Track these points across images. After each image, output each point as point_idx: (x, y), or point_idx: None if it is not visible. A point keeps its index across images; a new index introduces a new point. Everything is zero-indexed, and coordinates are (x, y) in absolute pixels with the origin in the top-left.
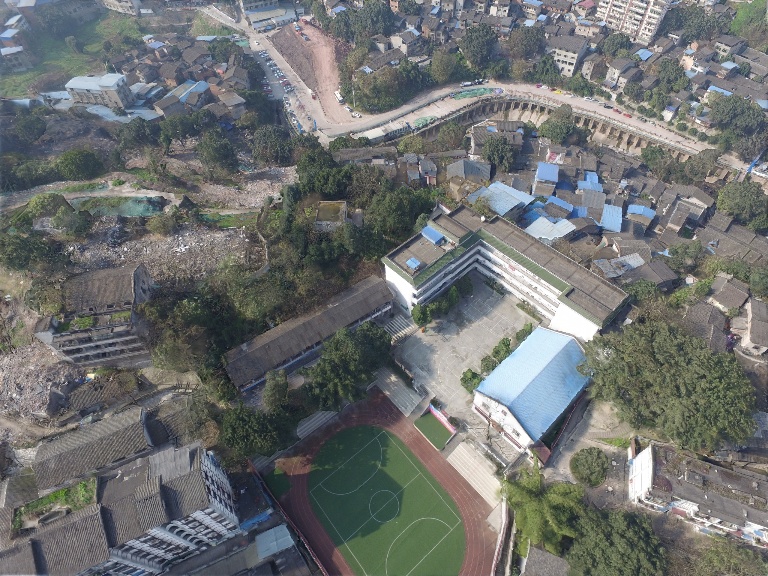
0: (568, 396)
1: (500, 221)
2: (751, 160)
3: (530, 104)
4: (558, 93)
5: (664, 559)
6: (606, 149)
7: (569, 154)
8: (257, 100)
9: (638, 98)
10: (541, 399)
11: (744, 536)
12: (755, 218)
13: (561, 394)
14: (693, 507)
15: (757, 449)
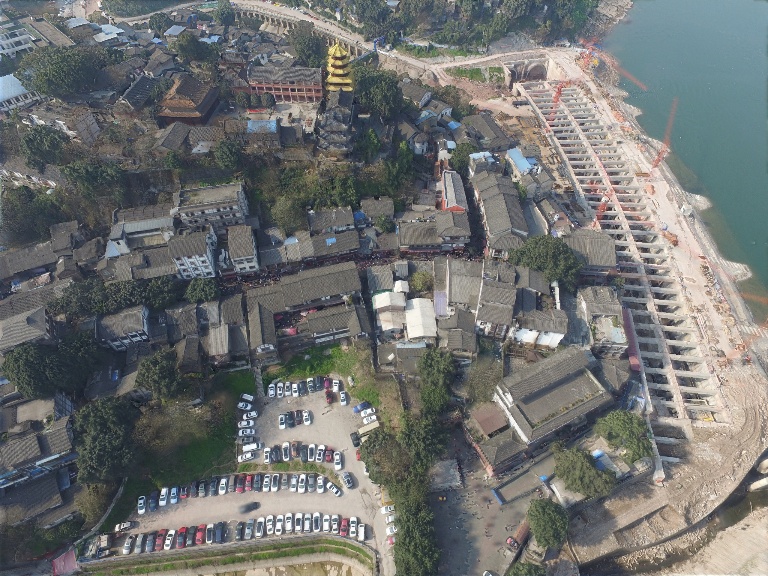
0: (22, 90)
1: (44, 21)
2: (381, 44)
3: (254, 13)
4: (276, 5)
5: (3, 132)
6: (266, 32)
7: (212, 26)
8: (29, 4)
9: (324, 5)
10: (0, 88)
11: (70, 137)
12: (309, 59)
13: (16, 88)
14: (42, 121)
15: (96, 103)
